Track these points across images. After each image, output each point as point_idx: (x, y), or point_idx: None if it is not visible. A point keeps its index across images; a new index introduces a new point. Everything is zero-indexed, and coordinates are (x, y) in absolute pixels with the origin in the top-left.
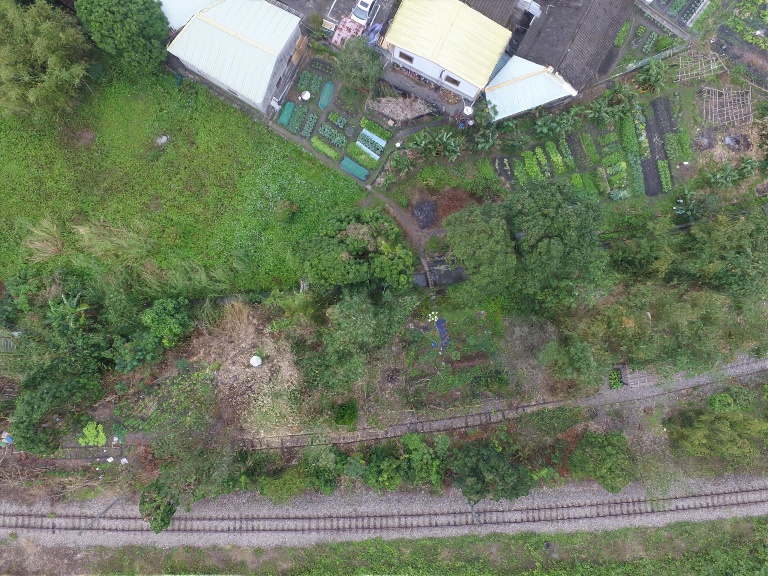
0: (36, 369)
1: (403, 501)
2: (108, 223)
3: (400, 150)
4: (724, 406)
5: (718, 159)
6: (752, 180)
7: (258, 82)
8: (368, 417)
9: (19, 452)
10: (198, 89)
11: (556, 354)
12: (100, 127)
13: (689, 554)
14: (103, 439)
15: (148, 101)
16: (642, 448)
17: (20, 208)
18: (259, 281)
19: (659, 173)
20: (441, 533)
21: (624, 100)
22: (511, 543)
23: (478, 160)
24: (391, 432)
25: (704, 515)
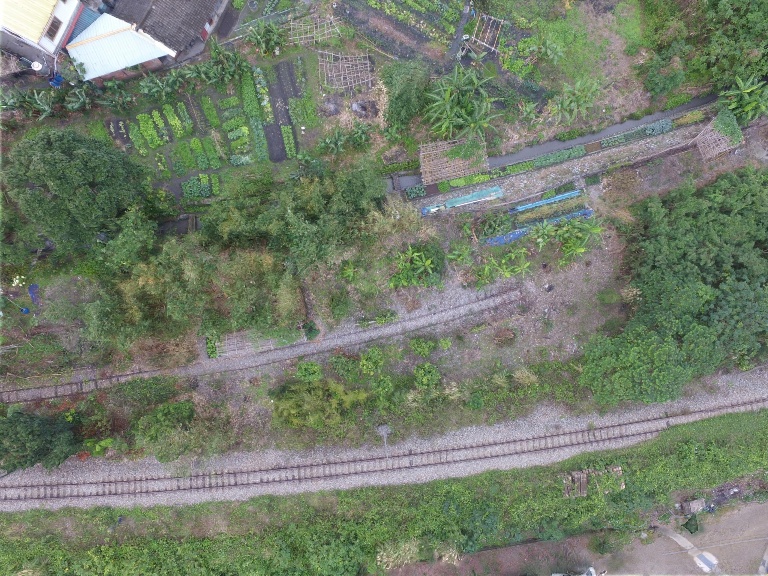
0: None
1: None
2: None
3: (7, 111)
4: (308, 374)
5: (344, 125)
6: (379, 147)
7: None
8: None
9: None
10: None
11: (67, 313)
12: None
13: (271, 529)
14: None
15: None
16: (243, 420)
17: None
18: None
19: (283, 139)
20: (10, 507)
21: (223, 61)
22: (83, 518)
23: (89, 122)
24: None
25: (289, 488)
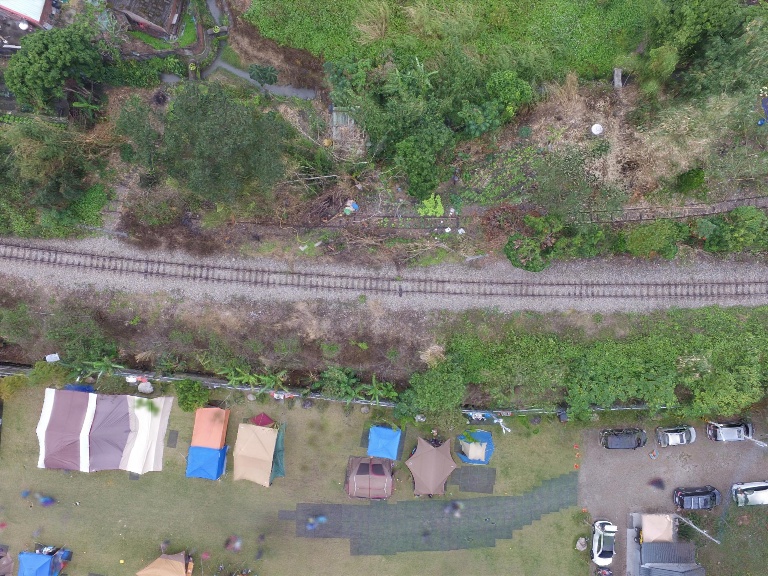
0: (401, 124)
1: (739, 270)
2: (433, 6)
3: None
4: None
5: None
6: None
7: None
8: (697, 192)
9: (361, 221)
10: None
11: None
12: None
13: None
14: (441, 209)
15: None
16: None
17: None
18: (575, 67)
19: None
20: None
21: None
22: None
23: None
24: (718, 208)
25: None
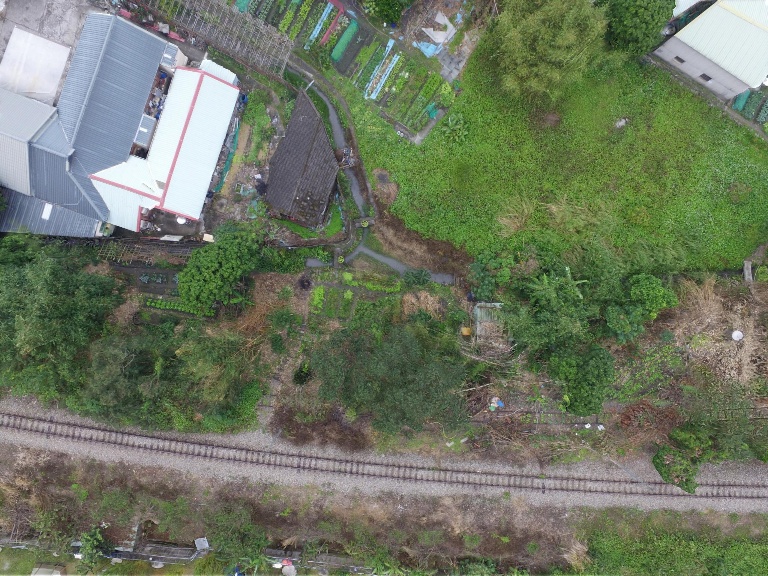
0: None
1: None
2: (572, 201)
3: None
4: None
5: None
6: None
7: (762, 67)
8: None
9: (504, 416)
10: (659, 74)
11: None
12: (566, 109)
13: None
14: None
15: (613, 85)
16: None
17: (490, 185)
18: (706, 260)
19: None
20: None
21: None
22: None
23: None
24: None
25: None
